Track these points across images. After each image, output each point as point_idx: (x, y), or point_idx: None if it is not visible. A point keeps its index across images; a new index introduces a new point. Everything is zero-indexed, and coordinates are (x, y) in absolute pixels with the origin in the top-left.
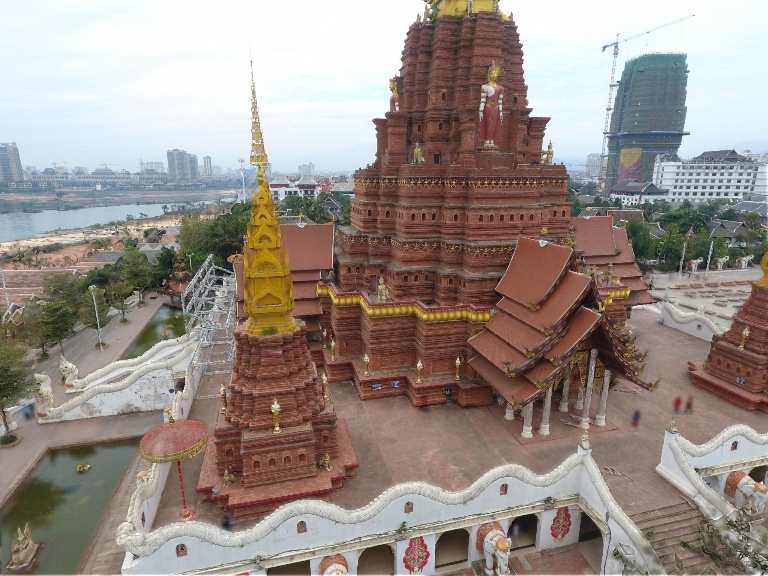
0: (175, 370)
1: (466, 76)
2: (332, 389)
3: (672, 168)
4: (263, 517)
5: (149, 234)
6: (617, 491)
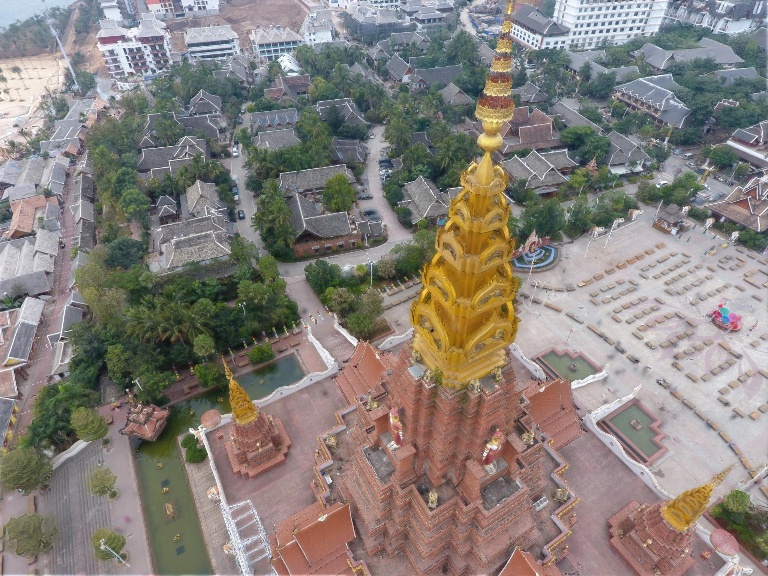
0: None
1: (471, 433)
2: None
3: (576, 3)
4: None
5: None
6: None
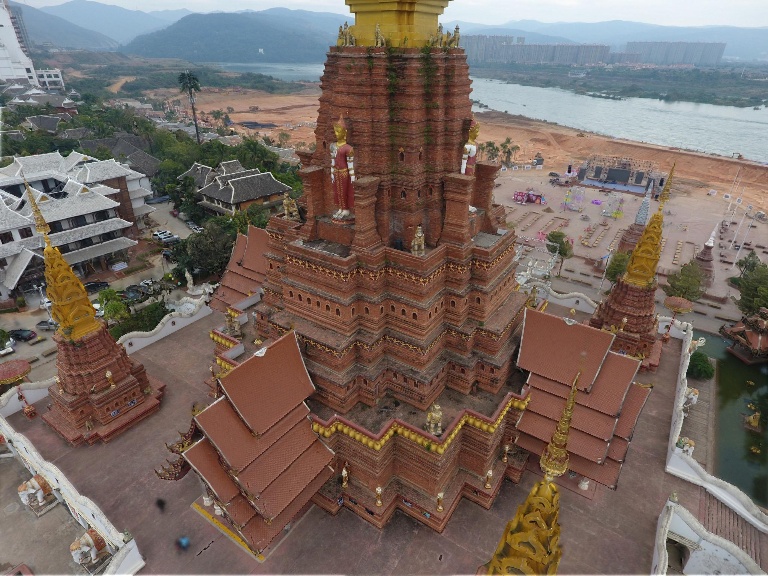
0: None
1: None
2: None
3: None
4: None
5: None
6: None
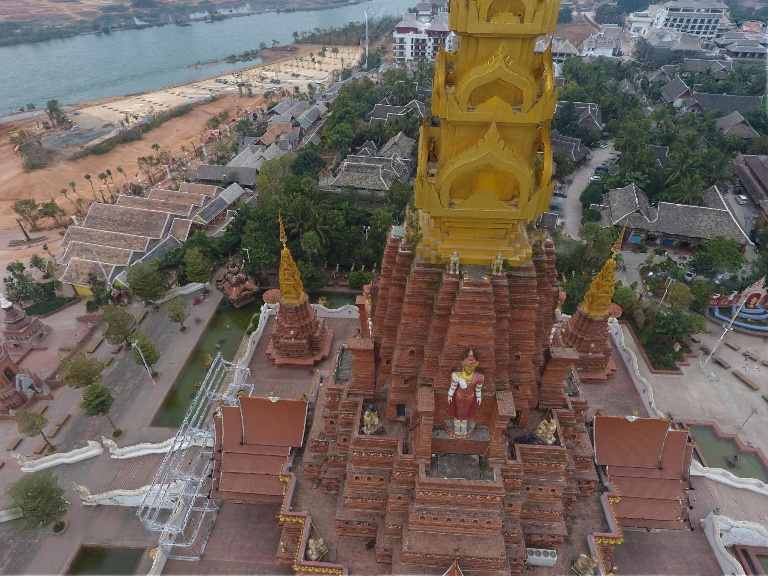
0: (172, 492)
1: (438, 347)
2: None
3: None
4: None
5: (264, 103)
6: None
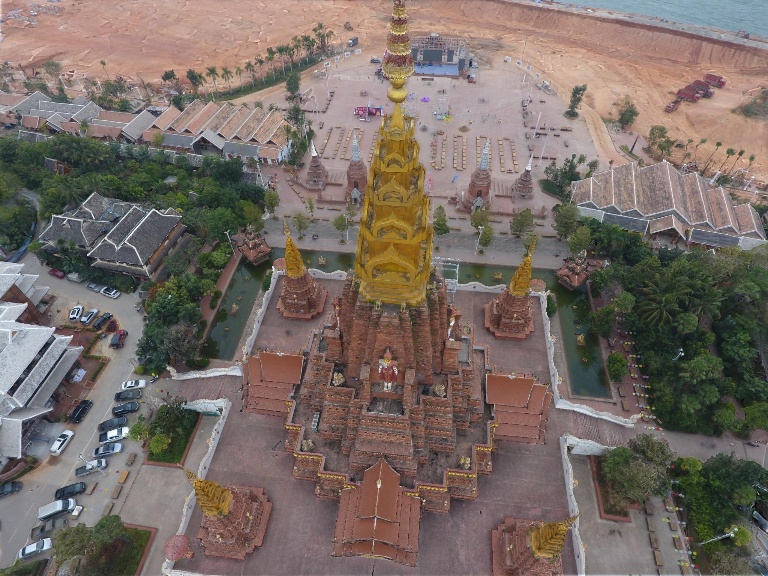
0: None
1: None
2: None
3: None
4: None
5: None
6: (234, 384)
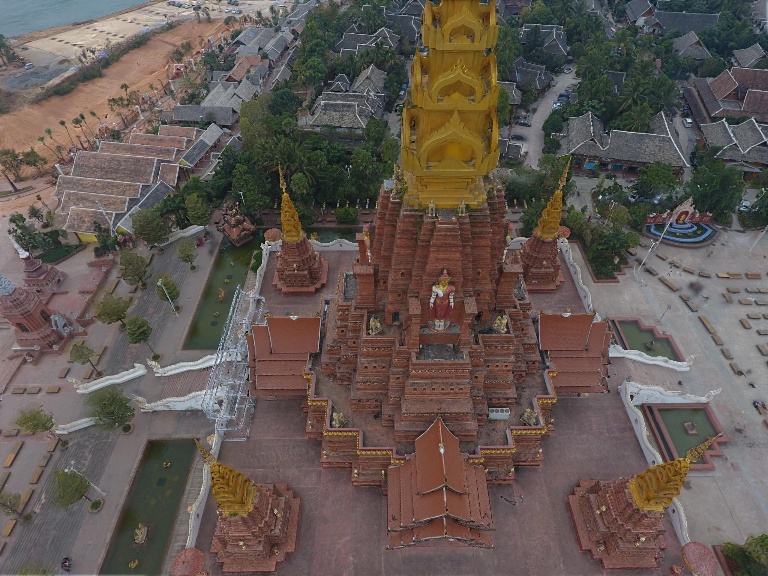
0: None
1: (422, 269)
2: (308, 447)
3: None
4: (241, 574)
5: (226, 31)
6: None
